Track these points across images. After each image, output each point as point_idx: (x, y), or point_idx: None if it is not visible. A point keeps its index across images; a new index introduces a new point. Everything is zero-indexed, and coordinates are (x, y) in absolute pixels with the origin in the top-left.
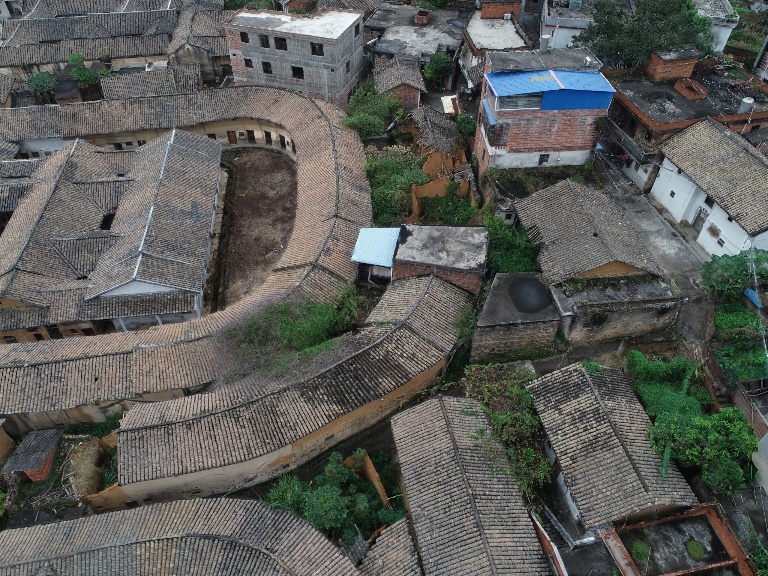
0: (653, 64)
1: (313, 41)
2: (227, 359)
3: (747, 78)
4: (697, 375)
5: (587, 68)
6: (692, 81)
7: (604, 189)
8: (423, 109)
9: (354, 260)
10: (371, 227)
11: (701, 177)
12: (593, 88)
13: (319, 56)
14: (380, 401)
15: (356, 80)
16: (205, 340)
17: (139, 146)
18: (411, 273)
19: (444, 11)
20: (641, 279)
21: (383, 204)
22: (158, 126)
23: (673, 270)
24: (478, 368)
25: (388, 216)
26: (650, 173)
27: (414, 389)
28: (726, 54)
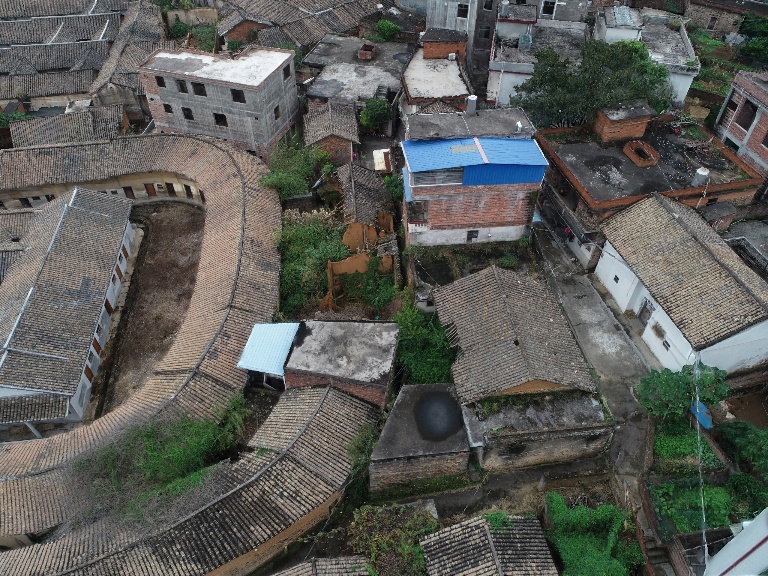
0: (600, 123)
1: (233, 87)
2: (78, 496)
3: (707, 138)
4: (626, 527)
5: (518, 135)
6: (643, 143)
7: (539, 272)
8: (349, 167)
9: (240, 367)
10: (273, 316)
11: (643, 269)
12: (522, 161)
13: (241, 103)
14: (254, 550)
15: (290, 124)
16: (54, 472)
17: (47, 201)
18: (306, 383)
19: (392, 44)
20: (569, 395)
21: (294, 283)
22: (65, 180)
23: (612, 376)
24: (369, 512)
25: (300, 297)
26: (593, 251)
27: (300, 529)
28: (692, 98)
